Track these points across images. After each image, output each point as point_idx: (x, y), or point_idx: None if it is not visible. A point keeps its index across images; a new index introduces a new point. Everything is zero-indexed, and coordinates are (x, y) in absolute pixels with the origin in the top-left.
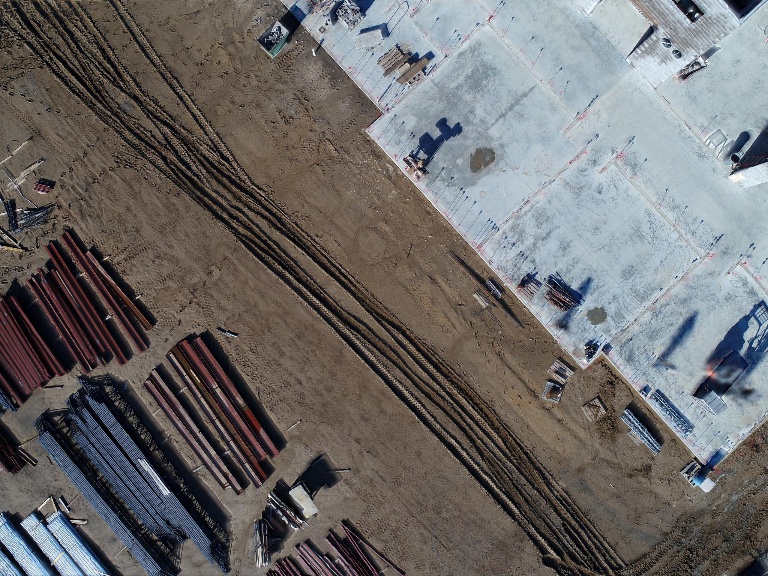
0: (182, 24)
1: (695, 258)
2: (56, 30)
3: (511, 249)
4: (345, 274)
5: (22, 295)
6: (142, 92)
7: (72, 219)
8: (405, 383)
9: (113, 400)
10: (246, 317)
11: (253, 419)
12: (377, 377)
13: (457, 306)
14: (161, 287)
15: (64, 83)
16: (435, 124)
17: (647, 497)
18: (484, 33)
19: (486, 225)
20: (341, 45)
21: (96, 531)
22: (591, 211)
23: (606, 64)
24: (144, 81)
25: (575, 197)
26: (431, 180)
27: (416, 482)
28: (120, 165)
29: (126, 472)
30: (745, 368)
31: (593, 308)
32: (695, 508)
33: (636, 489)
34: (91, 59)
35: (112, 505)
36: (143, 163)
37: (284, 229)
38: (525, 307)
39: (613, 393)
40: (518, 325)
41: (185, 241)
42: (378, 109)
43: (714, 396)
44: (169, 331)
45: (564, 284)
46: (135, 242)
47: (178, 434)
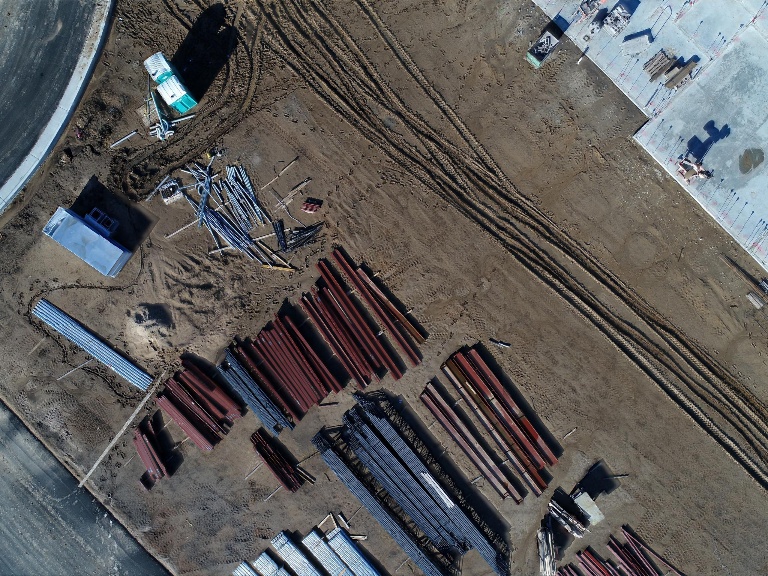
0: (444, 39)
1: None
2: (318, 50)
3: None
4: (616, 280)
5: (293, 314)
6: (406, 108)
7: (340, 237)
8: (680, 387)
9: (388, 415)
10: (518, 327)
11: (530, 428)
12: (652, 382)
13: (730, 308)
14: (431, 301)
15: (328, 102)
16: (703, 127)
17: None
18: (748, 34)
19: (758, 226)
20: (606, 52)
21: (376, 546)
22: None
23: None
24: (407, 97)
25: None
26: (701, 183)
27: (695, 485)
28: (386, 181)
29: (409, 486)
30: None
31: None
32: None
33: None
34: (353, 77)
35: (395, 520)
36: (409, 178)
37: (553, 238)
38: None
39: None
40: None
41: (454, 254)
42: (644, 114)
43: None
44: (441, 344)
45: None
46: (404, 257)
47: (454, 446)
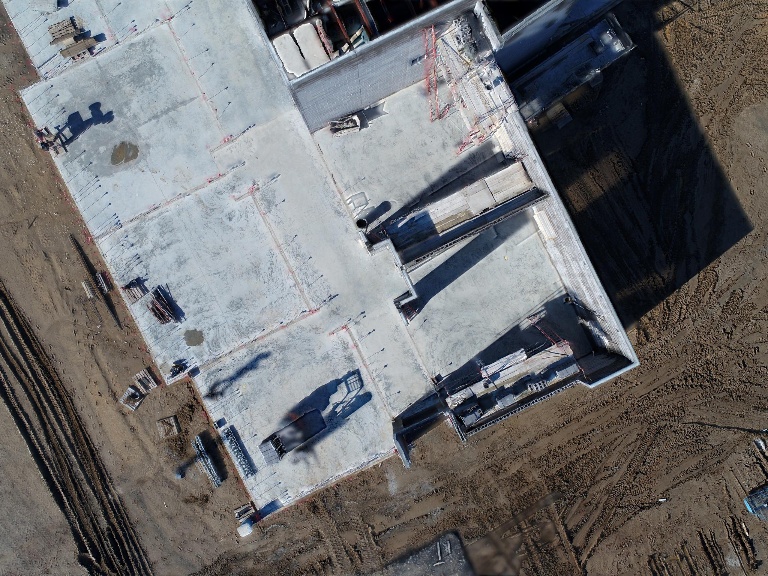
0: None
1: (305, 309)
2: None
3: (128, 249)
4: None
5: None
6: None
7: None
8: None
9: None
10: None
11: None
12: None
13: (64, 289)
14: None
15: None
16: (89, 106)
17: (196, 525)
18: (161, 31)
19: (111, 219)
20: (18, 1)
21: None
22: (217, 235)
23: (272, 96)
24: None
25: (205, 217)
26: (69, 159)
27: None
28: None
29: None
30: (322, 429)
31: (192, 329)
32: (240, 549)
33: (188, 515)
34: None
35: None
36: None
37: None
38: (128, 309)
39: (190, 416)
40: (117, 324)
41: None
42: (39, 75)
43: (270, 446)
44: None
45: (171, 298)
46: None
47: None
